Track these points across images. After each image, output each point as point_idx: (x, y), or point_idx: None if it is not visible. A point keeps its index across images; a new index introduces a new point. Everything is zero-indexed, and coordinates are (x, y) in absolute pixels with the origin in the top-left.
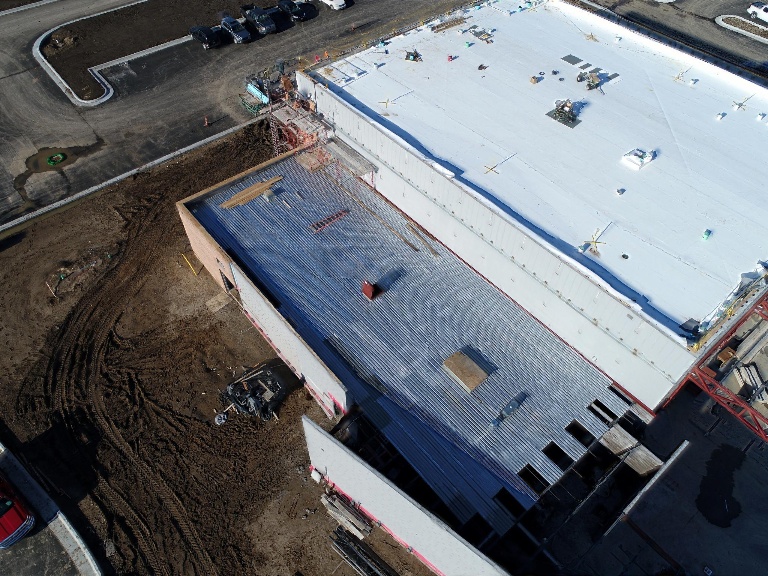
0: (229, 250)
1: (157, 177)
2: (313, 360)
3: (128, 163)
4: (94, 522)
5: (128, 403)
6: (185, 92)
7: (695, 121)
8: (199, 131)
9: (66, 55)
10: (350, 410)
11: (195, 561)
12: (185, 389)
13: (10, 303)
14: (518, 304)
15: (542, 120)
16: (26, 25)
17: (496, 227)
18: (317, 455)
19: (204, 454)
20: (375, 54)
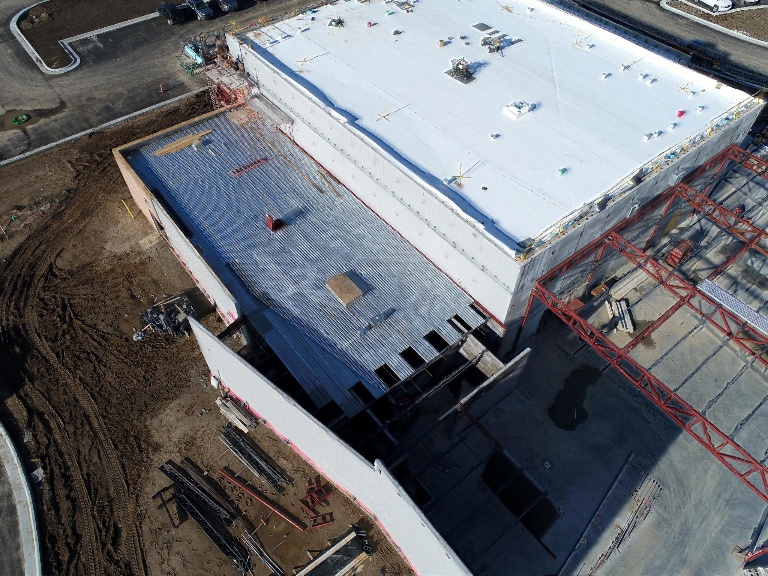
0: (154, 190)
1: (110, 136)
2: (212, 279)
3: (86, 123)
4: (17, 415)
5: (58, 322)
6: (146, 63)
7: (580, 80)
8: (154, 97)
9: (40, 29)
10: (238, 319)
11: (100, 447)
12: None
13: None
14: (403, 237)
15: (440, 77)
16: (7, 2)
17: (378, 165)
18: (210, 359)
19: (120, 364)
20: (302, 21)
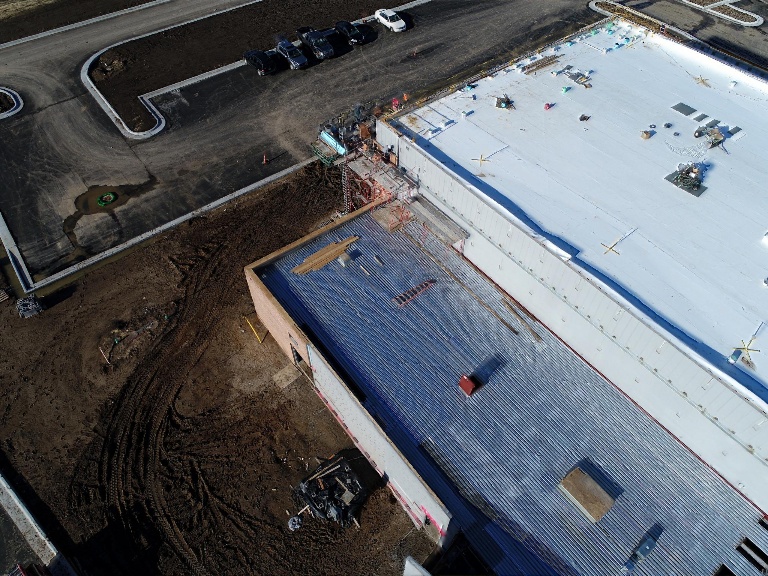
0: (304, 326)
1: (214, 223)
2: (408, 472)
3: (183, 205)
4: None
5: (191, 499)
6: (240, 124)
7: None
8: (257, 169)
9: (115, 81)
10: (455, 540)
11: None
12: (253, 483)
13: (61, 369)
14: (640, 406)
15: (661, 186)
16: (74, 46)
17: (624, 323)
18: None
19: (278, 568)
20: (461, 99)
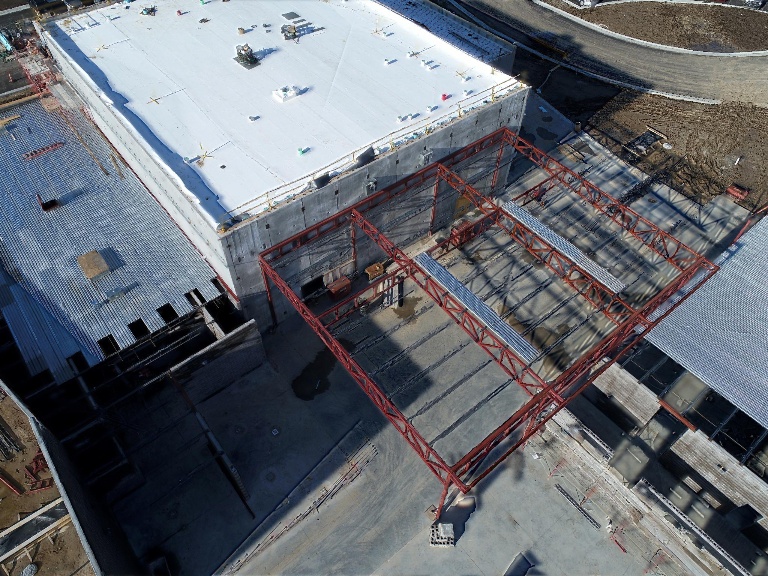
0: None
1: None
2: None
3: None
4: None
5: None
6: None
7: (363, 66)
8: (3, 86)
9: None
10: None
11: None
12: None
13: None
14: (171, 216)
15: (227, 63)
16: None
17: None
18: None
19: None
20: (116, 9)
